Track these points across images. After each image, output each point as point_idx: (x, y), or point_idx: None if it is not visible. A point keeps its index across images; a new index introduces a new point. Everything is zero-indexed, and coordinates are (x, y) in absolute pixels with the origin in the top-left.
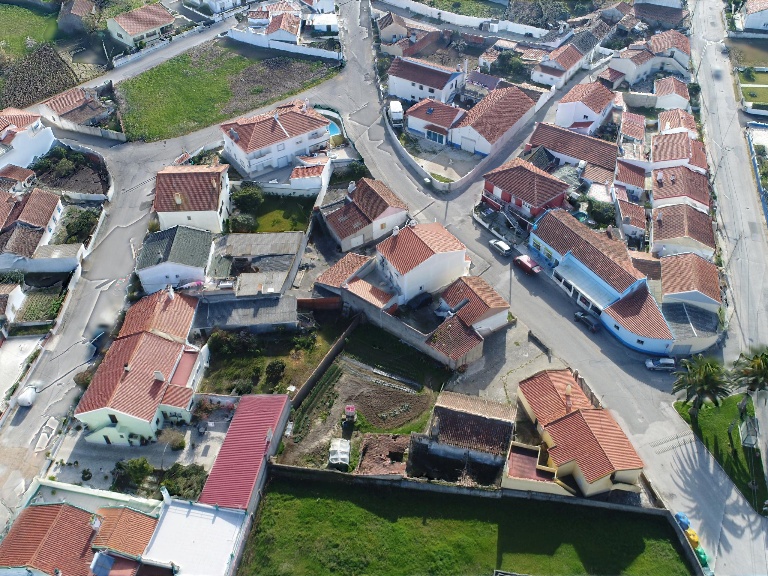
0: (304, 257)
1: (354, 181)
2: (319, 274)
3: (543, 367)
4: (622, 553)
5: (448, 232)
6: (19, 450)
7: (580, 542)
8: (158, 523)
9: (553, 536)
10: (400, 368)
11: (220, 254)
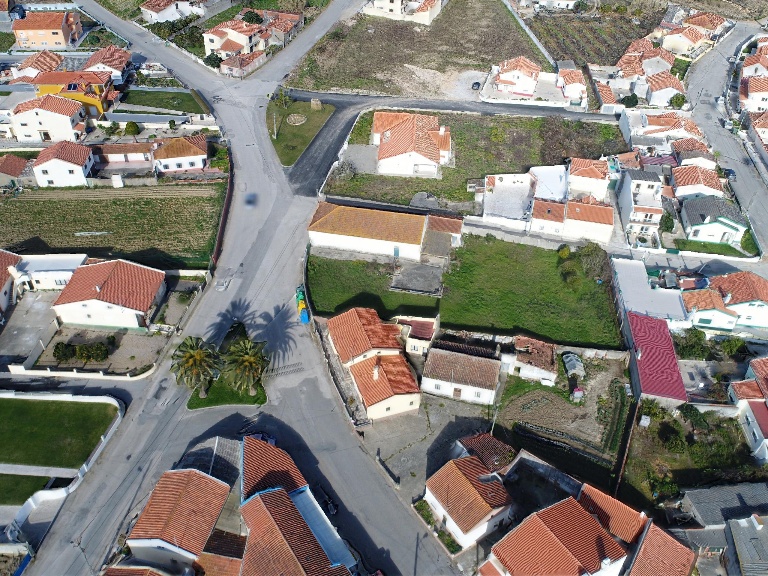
0: None
1: None
2: None
3: (388, 443)
4: (353, 304)
5: None
6: None
7: (381, 309)
8: (686, 310)
9: (400, 313)
10: (542, 448)
11: None
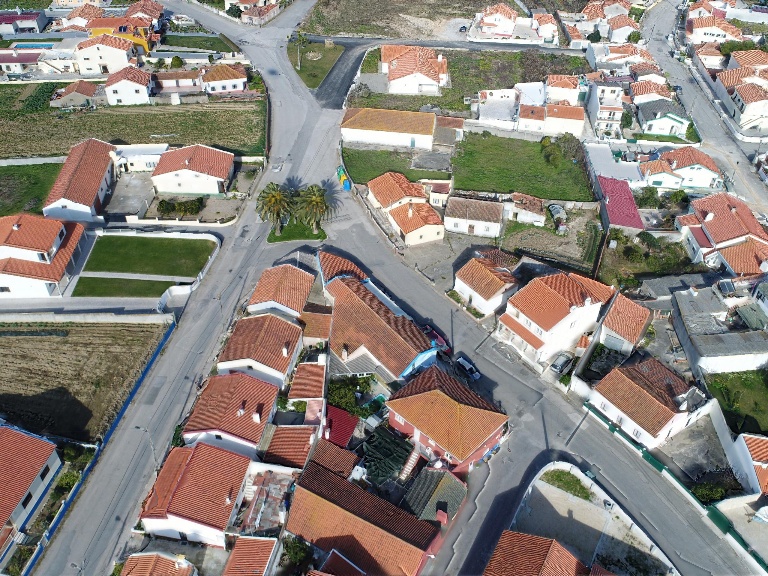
0: (687, 362)
1: (684, 404)
2: (657, 344)
3: (423, 260)
4: None
5: (533, 319)
6: (767, 212)
7: None
8: None
9: None
10: None
11: (767, 324)
